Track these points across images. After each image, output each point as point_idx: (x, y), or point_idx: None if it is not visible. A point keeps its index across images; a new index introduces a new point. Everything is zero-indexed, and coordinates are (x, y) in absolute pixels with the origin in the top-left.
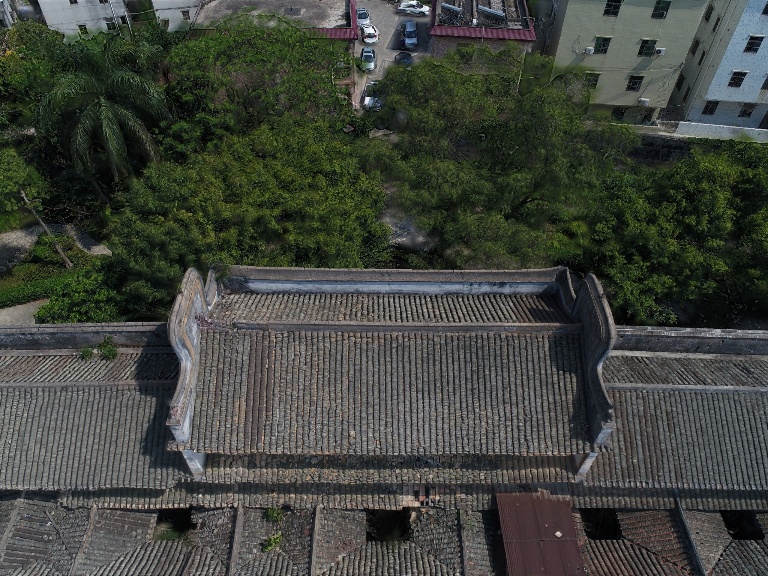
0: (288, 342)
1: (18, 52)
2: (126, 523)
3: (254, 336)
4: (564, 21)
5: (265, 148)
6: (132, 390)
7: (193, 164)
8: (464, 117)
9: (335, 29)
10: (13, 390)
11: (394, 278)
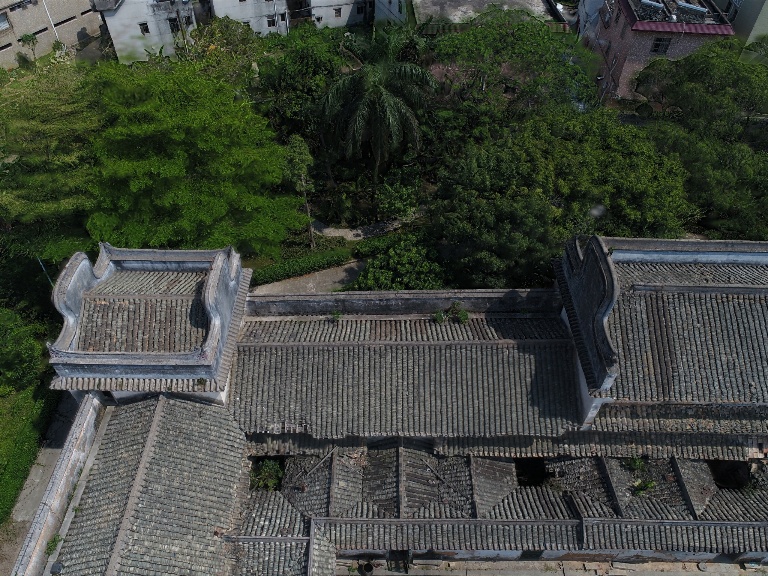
0: (679, 303)
1: (220, 47)
2: (496, 470)
3: (648, 297)
4: (759, 17)
5: (563, 132)
6: (510, 348)
7: (502, 147)
8: (761, 103)
9: (551, 24)
10: (401, 348)
11: (736, 249)
